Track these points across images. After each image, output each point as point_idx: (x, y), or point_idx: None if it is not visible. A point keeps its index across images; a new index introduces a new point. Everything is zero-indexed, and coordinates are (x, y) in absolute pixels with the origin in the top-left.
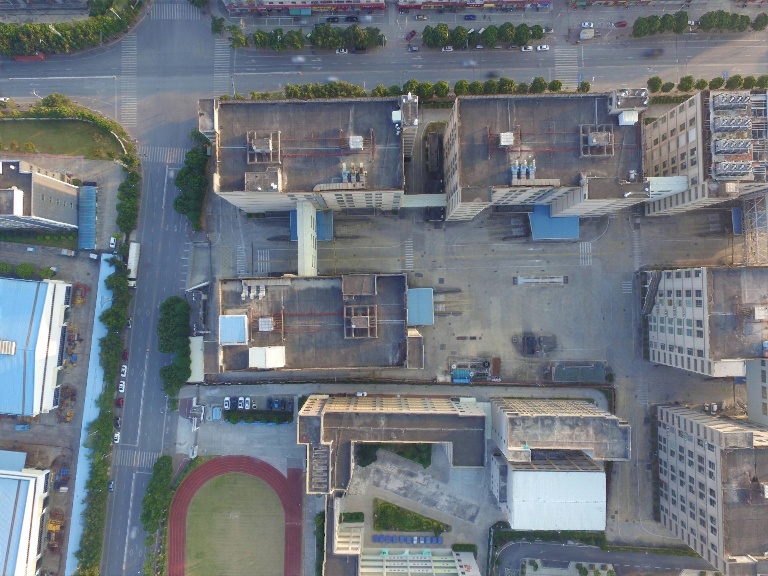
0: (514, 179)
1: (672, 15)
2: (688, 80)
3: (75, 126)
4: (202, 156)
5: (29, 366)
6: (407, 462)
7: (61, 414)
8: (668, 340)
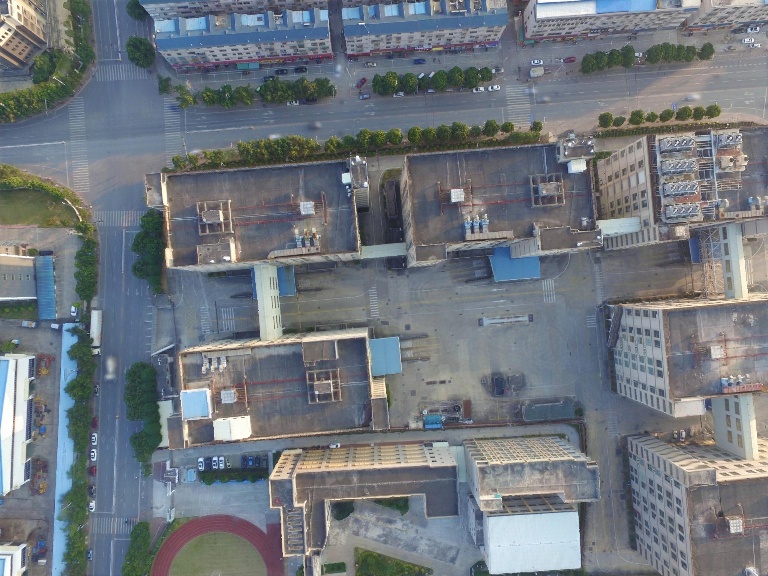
0: (468, 234)
1: (619, 50)
2: (638, 114)
3: (27, 195)
4: (158, 219)
5: None
6: (385, 509)
7: (34, 487)
8: (632, 375)
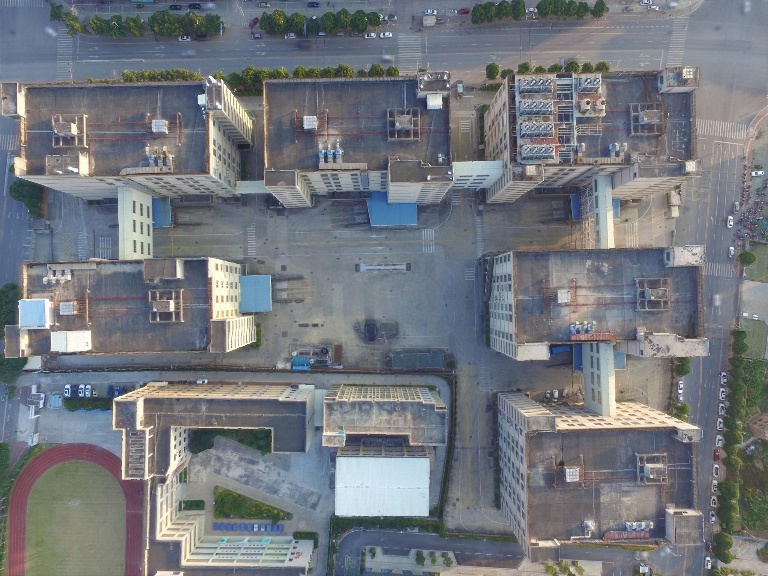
0: (321, 163)
1: (508, 2)
2: (525, 66)
3: None
4: None
5: None
6: (248, 450)
7: None
8: (498, 326)
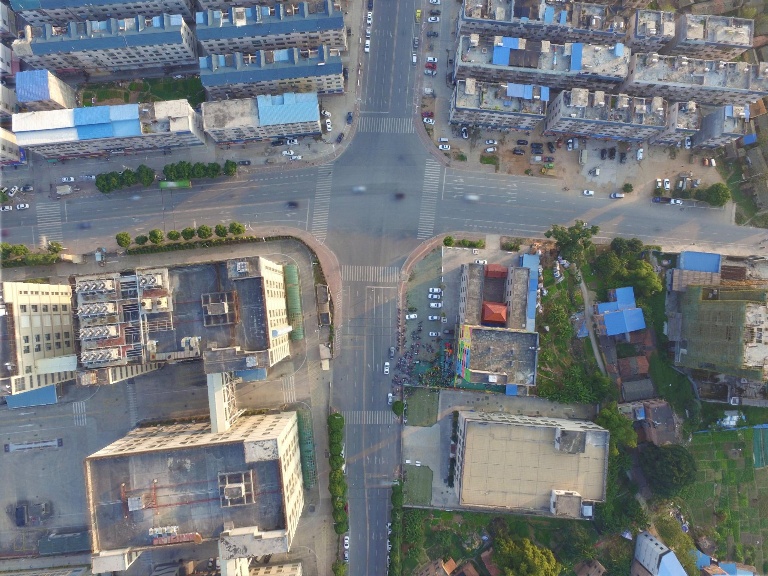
0: None
1: (131, 170)
2: (153, 234)
3: None
4: None
5: None
6: None
7: None
8: None
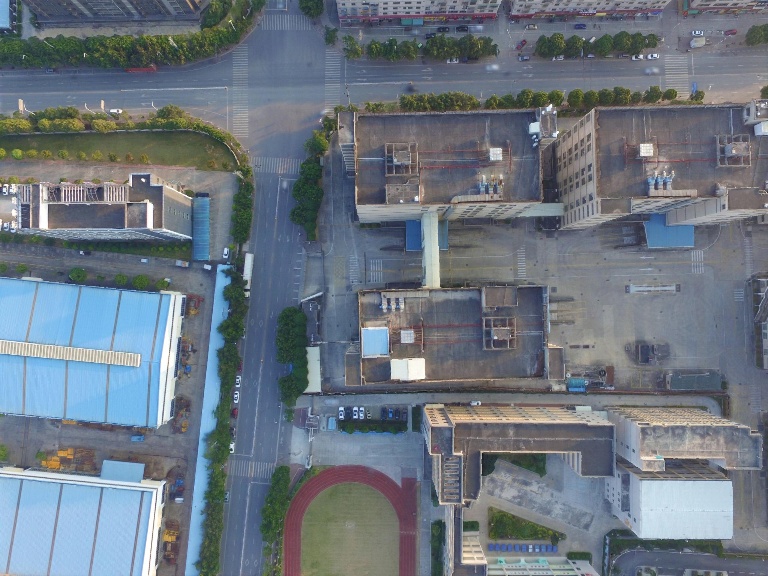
0: (651, 190)
1: None
2: None
3: (187, 137)
4: (318, 167)
5: (154, 378)
6: (521, 471)
7: (176, 425)
8: None
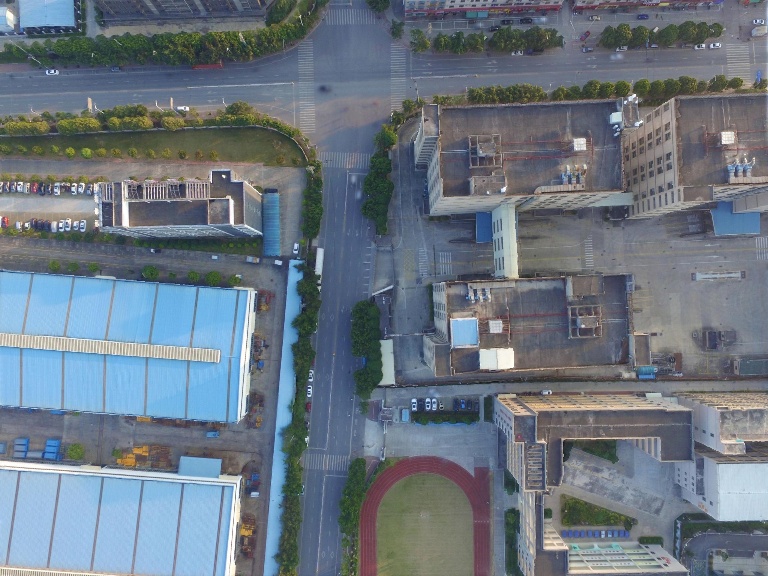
0: (732, 177)
1: None
2: None
3: (254, 133)
4: (388, 161)
5: (234, 373)
6: (593, 458)
7: (250, 420)
8: None
